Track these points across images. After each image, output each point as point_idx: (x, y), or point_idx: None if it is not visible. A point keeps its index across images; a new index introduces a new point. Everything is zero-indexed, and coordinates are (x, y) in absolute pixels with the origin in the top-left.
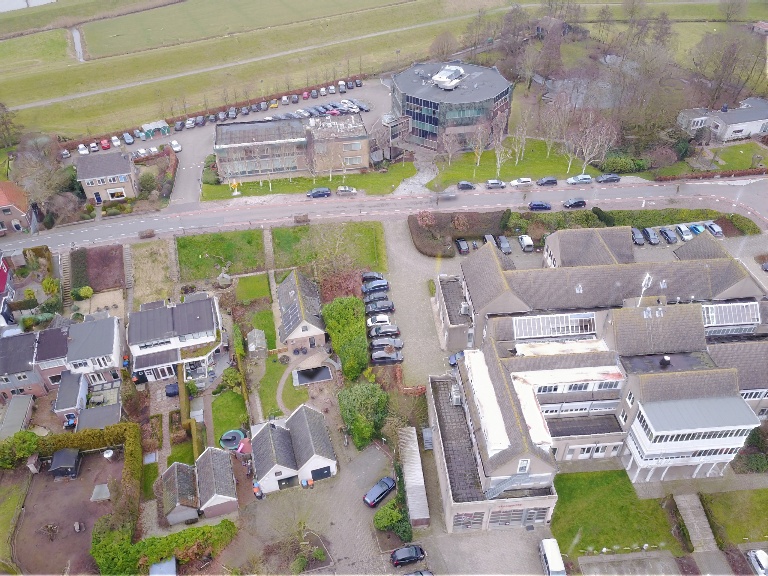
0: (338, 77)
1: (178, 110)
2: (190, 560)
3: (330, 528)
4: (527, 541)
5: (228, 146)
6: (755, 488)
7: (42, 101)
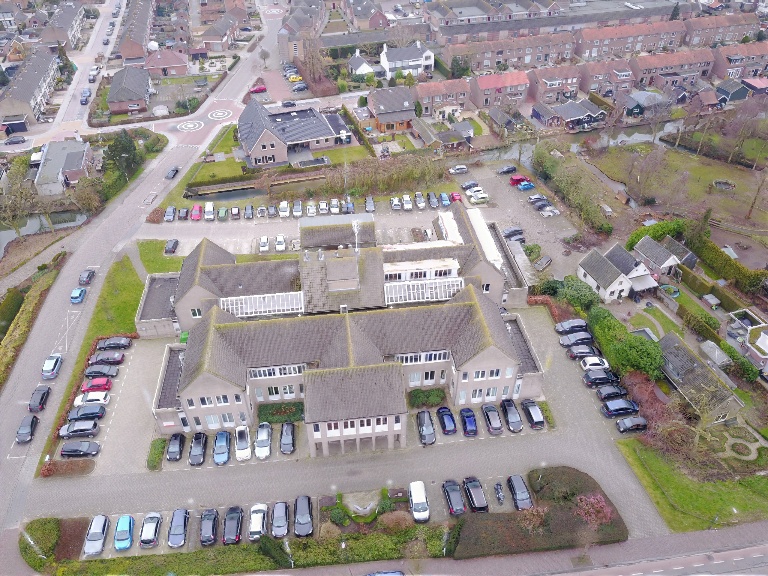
0: None
1: None
2: None
3: None
4: None
5: None
6: None
7: None
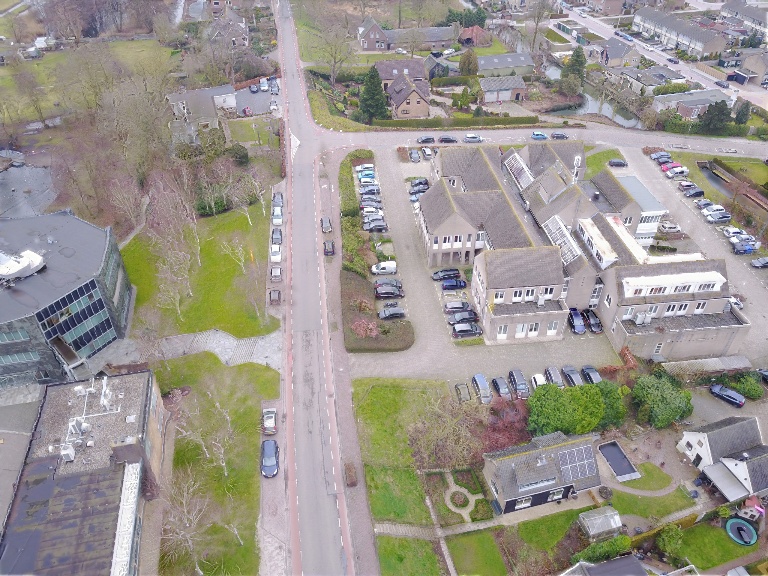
0: None
1: None
2: None
3: None
4: None
5: None
6: None
7: None
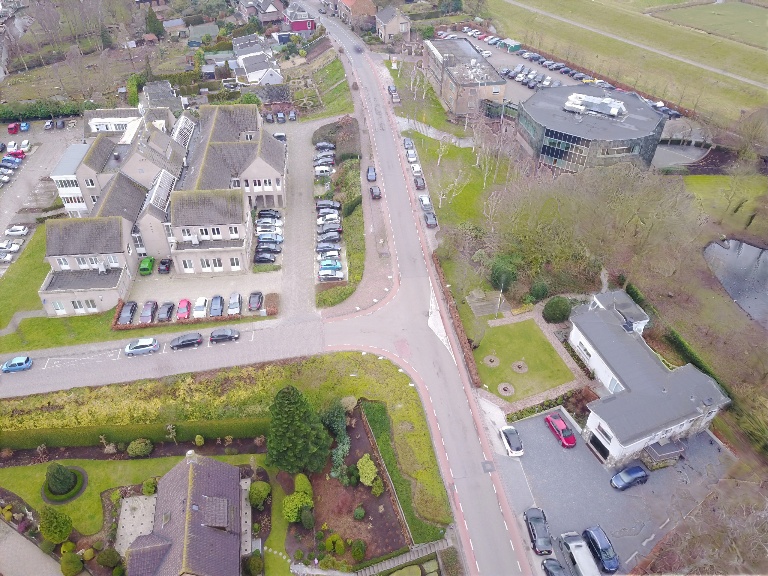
0: (691, 107)
1: (535, 43)
2: None
3: None
4: None
5: (431, 44)
6: None
7: (537, 9)
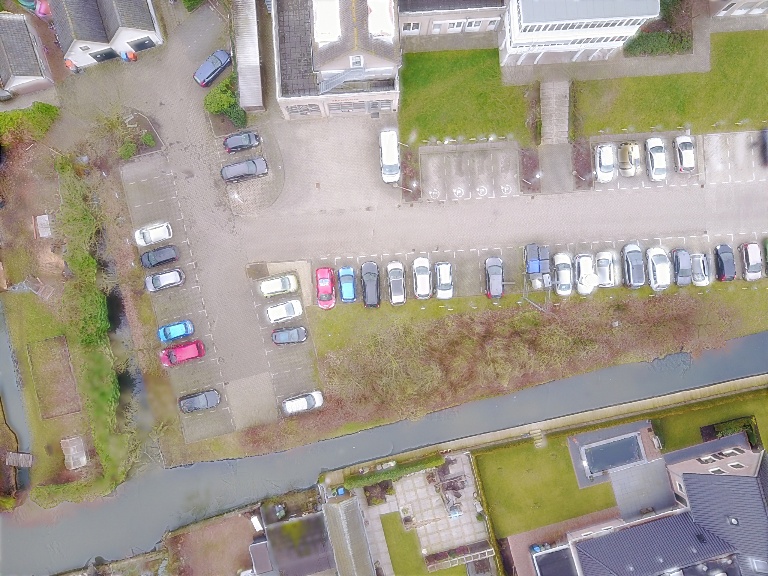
0: None
1: None
2: (12, 142)
3: (159, 109)
4: (369, 130)
5: None
6: (637, 75)
7: None
